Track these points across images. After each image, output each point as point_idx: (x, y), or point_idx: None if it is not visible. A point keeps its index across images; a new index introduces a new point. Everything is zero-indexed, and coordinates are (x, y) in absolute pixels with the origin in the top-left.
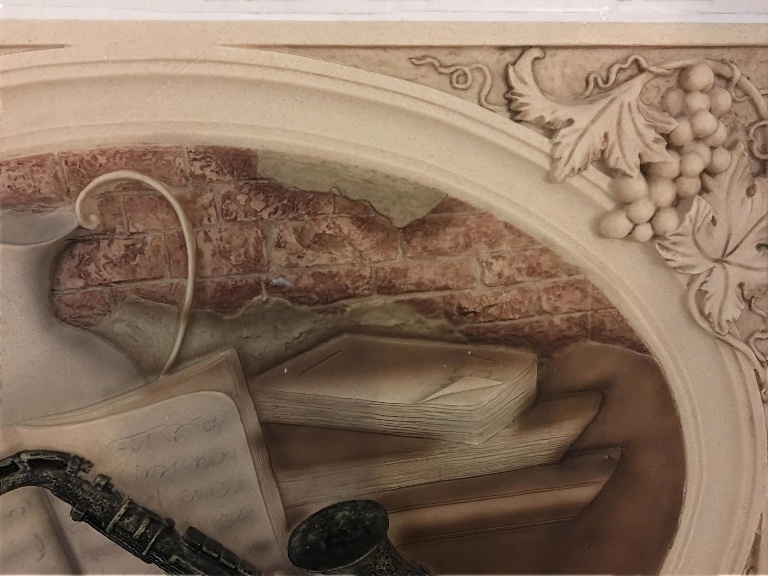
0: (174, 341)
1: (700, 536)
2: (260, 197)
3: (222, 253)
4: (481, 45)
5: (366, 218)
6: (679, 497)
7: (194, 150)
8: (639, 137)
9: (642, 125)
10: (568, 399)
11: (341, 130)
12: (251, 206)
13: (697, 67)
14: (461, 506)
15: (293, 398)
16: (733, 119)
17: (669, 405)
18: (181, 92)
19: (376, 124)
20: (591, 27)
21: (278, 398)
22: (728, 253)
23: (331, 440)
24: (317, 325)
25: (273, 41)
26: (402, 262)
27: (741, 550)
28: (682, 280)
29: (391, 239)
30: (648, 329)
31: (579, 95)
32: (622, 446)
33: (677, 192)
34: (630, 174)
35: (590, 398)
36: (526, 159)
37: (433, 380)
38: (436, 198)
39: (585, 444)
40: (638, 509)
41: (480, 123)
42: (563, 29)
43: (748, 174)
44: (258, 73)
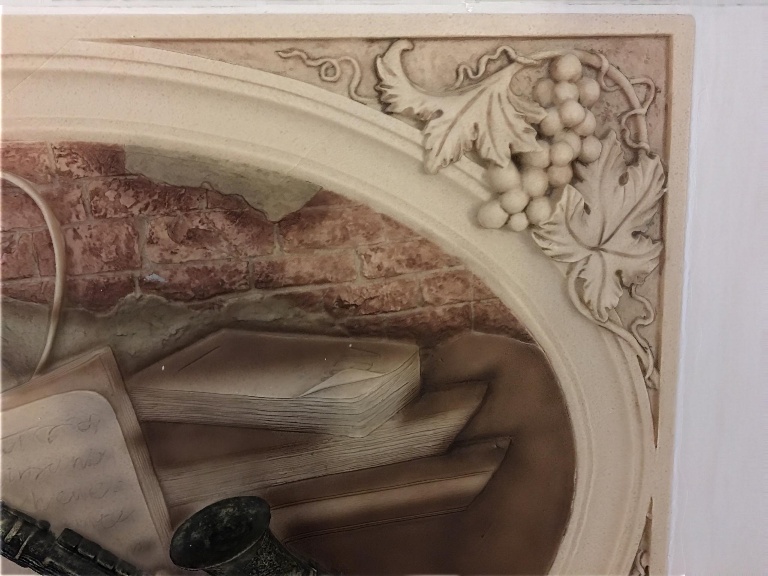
0: (46, 341)
1: (594, 522)
2: (130, 193)
3: (92, 250)
4: (347, 37)
5: (240, 212)
6: (570, 484)
7: (59, 146)
8: (509, 127)
9: (512, 115)
10: (454, 390)
11: (210, 124)
12: (121, 202)
13: (564, 57)
14: (348, 499)
15: (172, 395)
16: (605, 109)
17: (556, 393)
18: (43, 88)
19: (246, 118)
20: (457, 18)
21: (157, 396)
22: (604, 241)
23: (213, 437)
24: (194, 321)
25: (133, 35)
26: (279, 256)
27: (633, 534)
28: (561, 269)
29: (267, 233)
30: (531, 318)
31: (450, 86)
32: (511, 435)
33: (549, 181)
34: (500, 164)
35: (475, 388)
36: (399, 151)
37: (313, 374)
38: (310, 191)
39: (473, 434)
40: (530, 497)
41: (350, 115)
42: (429, 21)
43: (621, 163)
44: (120, 67)
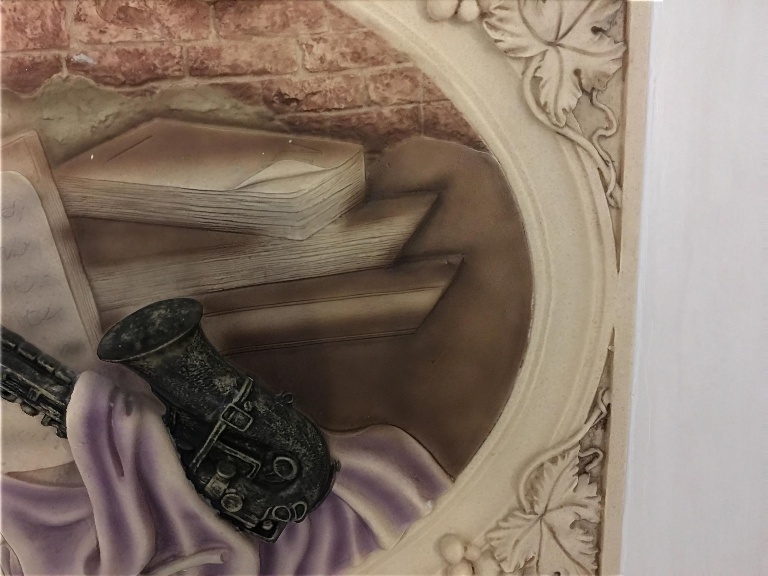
0: None
1: (553, 355)
2: None
3: (17, 25)
4: None
5: None
6: (527, 310)
7: None
8: None
9: None
10: (402, 198)
11: None
12: None
13: None
14: (289, 309)
15: (101, 187)
16: None
17: (511, 209)
18: None
19: None
20: None
21: (85, 187)
22: (561, 35)
23: (146, 235)
24: (124, 108)
25: None
26: (215, 42)
27: (593, 367)
28: (516, 68)
29: (201, 16)
30: (484, 124)
31: None
32: (463, 253)
33: None
34: None
35: (425, 197)
36: None
37: (250, 167)
38: None
39: (423, 249)
40: (484, 323)
41: None
42: None
43: None
44: None
